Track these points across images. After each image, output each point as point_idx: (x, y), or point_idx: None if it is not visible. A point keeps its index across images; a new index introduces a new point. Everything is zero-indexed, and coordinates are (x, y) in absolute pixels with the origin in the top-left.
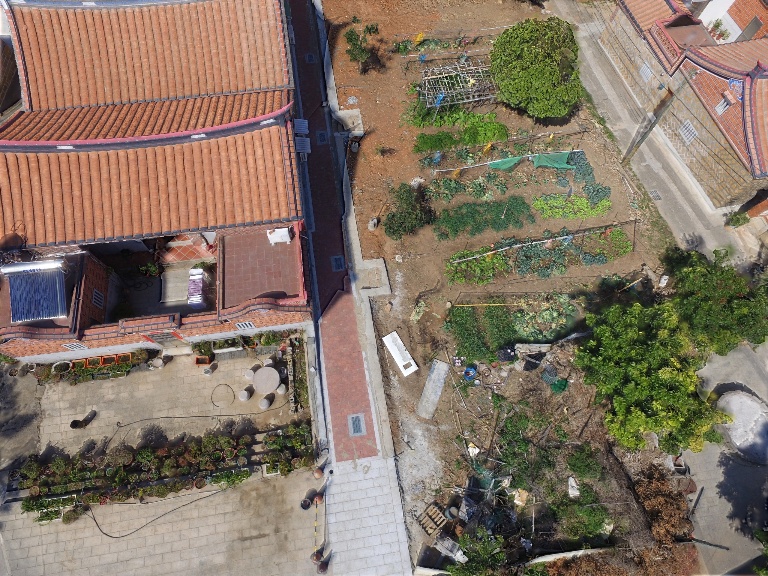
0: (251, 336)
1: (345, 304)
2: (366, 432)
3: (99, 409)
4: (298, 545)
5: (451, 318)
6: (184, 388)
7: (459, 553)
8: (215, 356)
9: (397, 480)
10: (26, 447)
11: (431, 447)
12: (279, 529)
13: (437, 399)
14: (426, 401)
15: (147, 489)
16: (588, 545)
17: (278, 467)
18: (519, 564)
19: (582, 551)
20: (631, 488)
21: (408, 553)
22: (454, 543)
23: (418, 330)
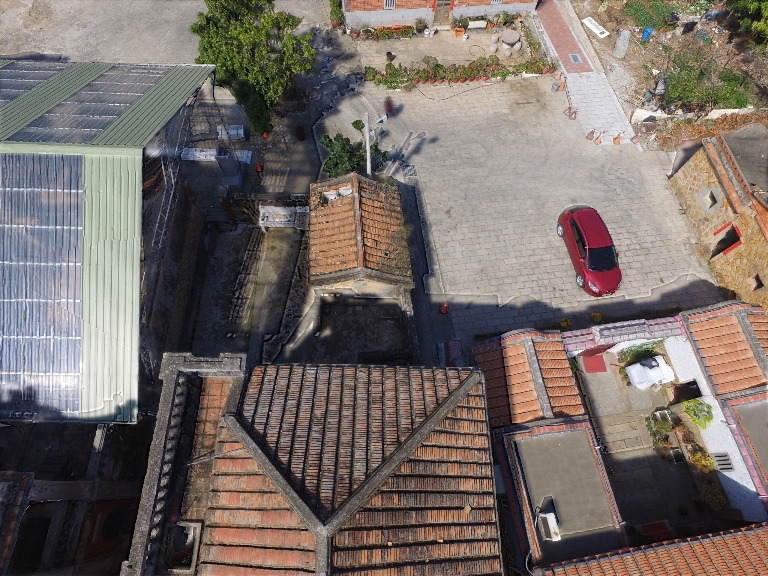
0: (490, 19)
1: (550, 5)
2: (583, 62)
3: (397, 54)
4: (554, 107)
5: (628, 8)
6: (450, 46)
7: (659, 111)
8: (466, 32)
9: (609, 83)
10: (357, 68)
11: (626, 71)
12: (540, 100)
13: (626, 49)
14: (618, 50)
15: (453, 75)
16: (741, 106)
17: (533, 71)
18: (699, 112)
19: (737, 110)
20: (764, 86)
21: (624, 114)
22: (656, 102)
23: (606, 15)
